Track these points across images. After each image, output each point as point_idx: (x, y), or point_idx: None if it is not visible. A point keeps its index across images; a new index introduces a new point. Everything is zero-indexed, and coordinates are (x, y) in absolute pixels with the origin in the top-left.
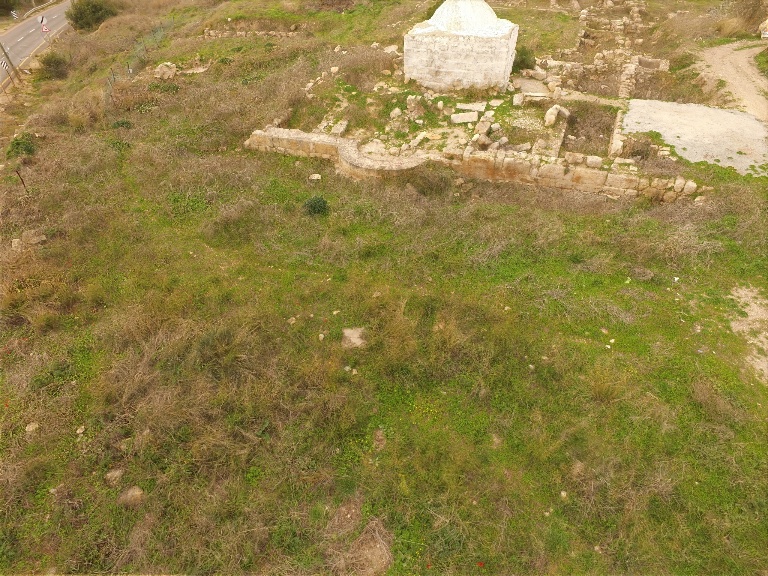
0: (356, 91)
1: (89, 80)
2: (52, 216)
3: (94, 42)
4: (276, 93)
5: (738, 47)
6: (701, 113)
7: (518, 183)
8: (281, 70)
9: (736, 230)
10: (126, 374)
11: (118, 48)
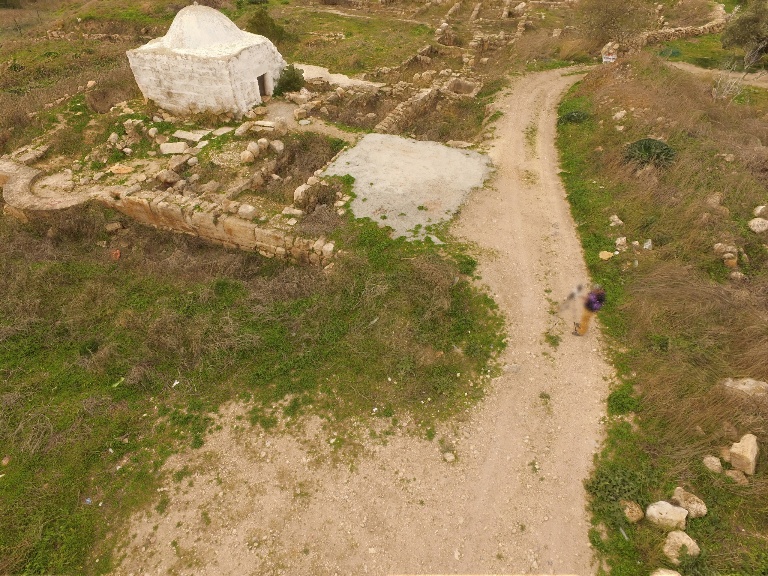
0: (82, 111)
1: None
2: None
3: None
4: None
5: (569, 72)
6: (429, 154)
7: None
8: None
9: (294, 318)
10: None
11: None
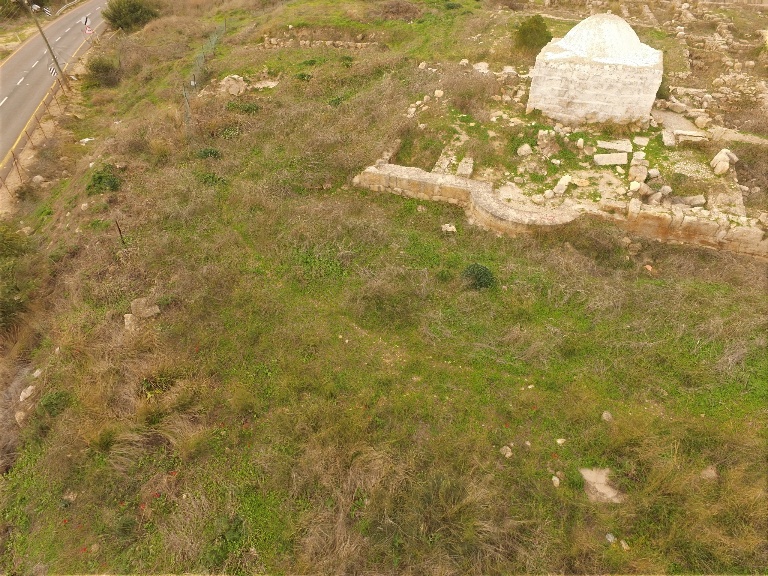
0: (475, 122)
1: (145, 91)
2: (160, 278)
3: (145, 47)
4: (376, 119)
5: None
6: None
7: (701, 247)
8: (366, 89)
9: None
10: (324, 542)
11: (172, 55)
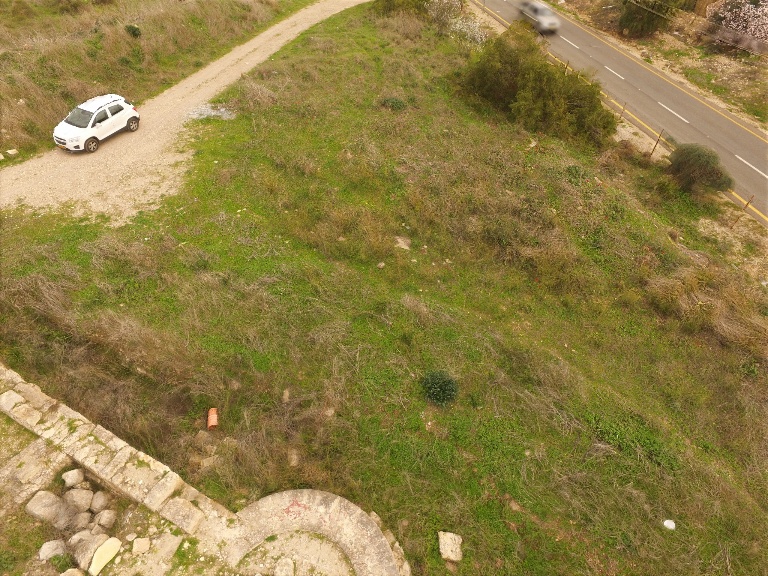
0: None
1: None
2: None
3: None
4: None
5: None
6: None
7: (131, 428)
8: None
9: None
10: None
11: None
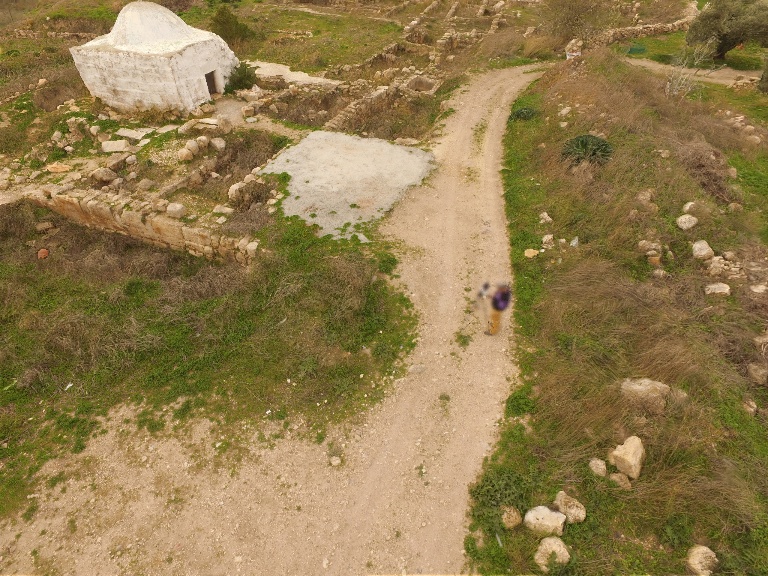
0: (27, 109)
1: None
2: None
3: None
4: None
5: (532, 69)
6: (371, 151)
7: None
8: None
9: (199, 319)
10: None
11: None
